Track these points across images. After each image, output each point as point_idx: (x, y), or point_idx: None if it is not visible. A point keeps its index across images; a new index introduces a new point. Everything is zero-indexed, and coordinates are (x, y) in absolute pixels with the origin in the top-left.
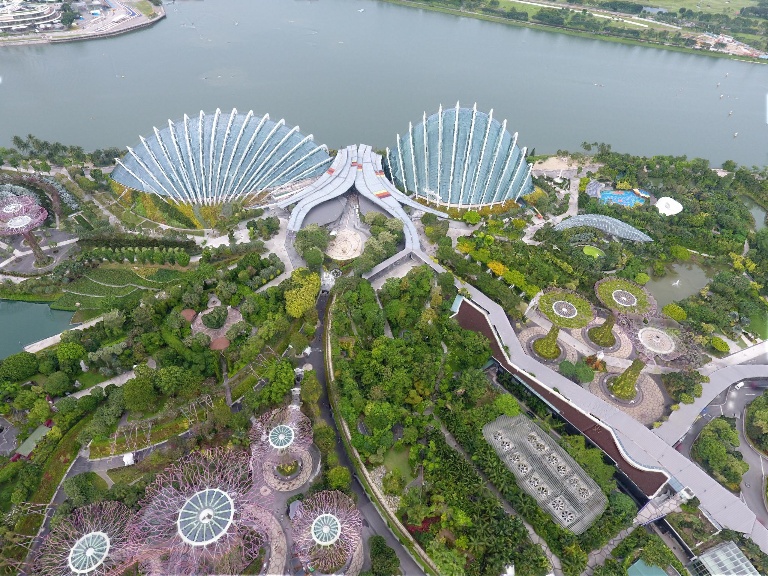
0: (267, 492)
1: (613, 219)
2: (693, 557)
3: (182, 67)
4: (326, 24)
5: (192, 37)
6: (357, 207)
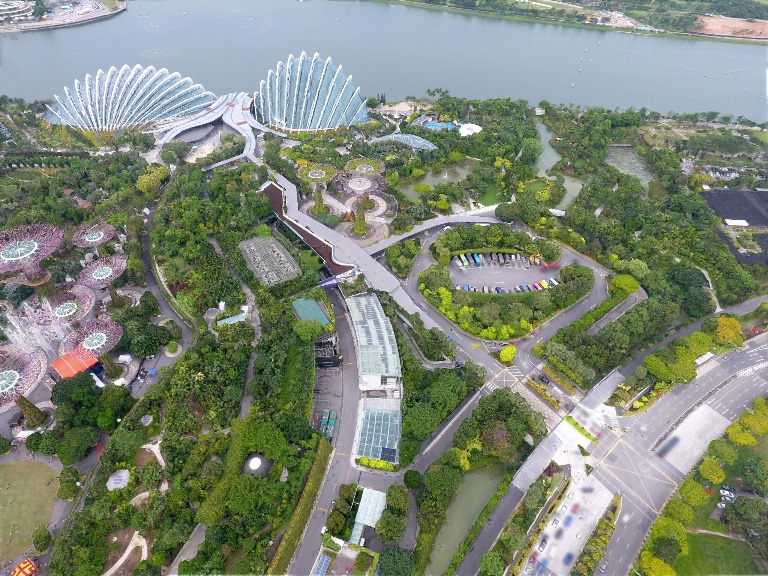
0: (58, 240)
1: (415, 136)
2: (345, 301)
3: (127, 47)
4: (264, 12)
5: (143, 24)
6: (221, 132)
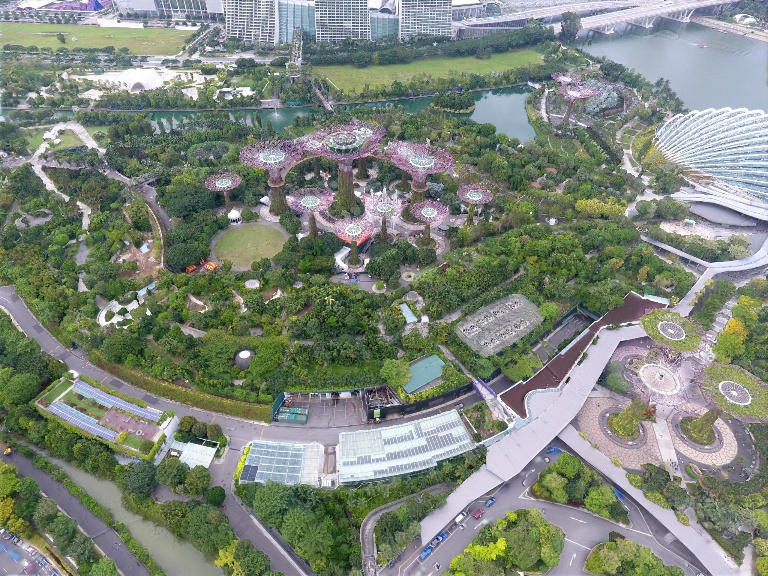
0: None
1: None
2: None
3: None
4: None
5: None
6: None
